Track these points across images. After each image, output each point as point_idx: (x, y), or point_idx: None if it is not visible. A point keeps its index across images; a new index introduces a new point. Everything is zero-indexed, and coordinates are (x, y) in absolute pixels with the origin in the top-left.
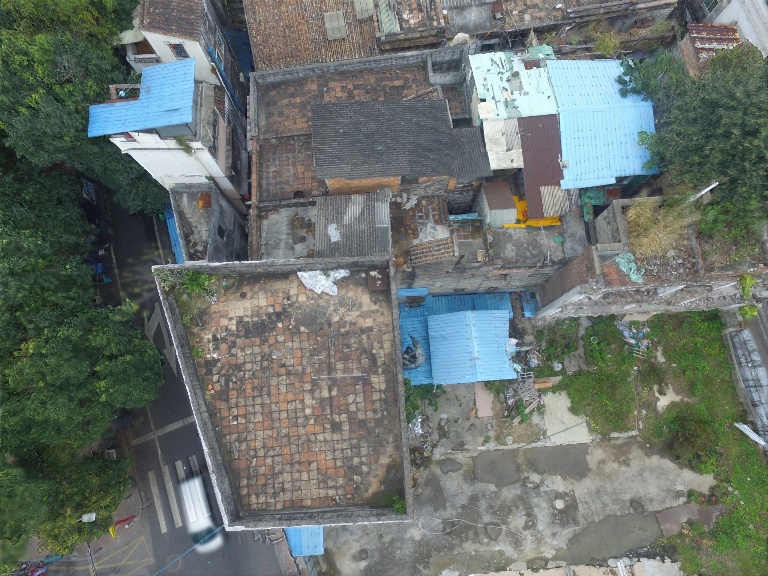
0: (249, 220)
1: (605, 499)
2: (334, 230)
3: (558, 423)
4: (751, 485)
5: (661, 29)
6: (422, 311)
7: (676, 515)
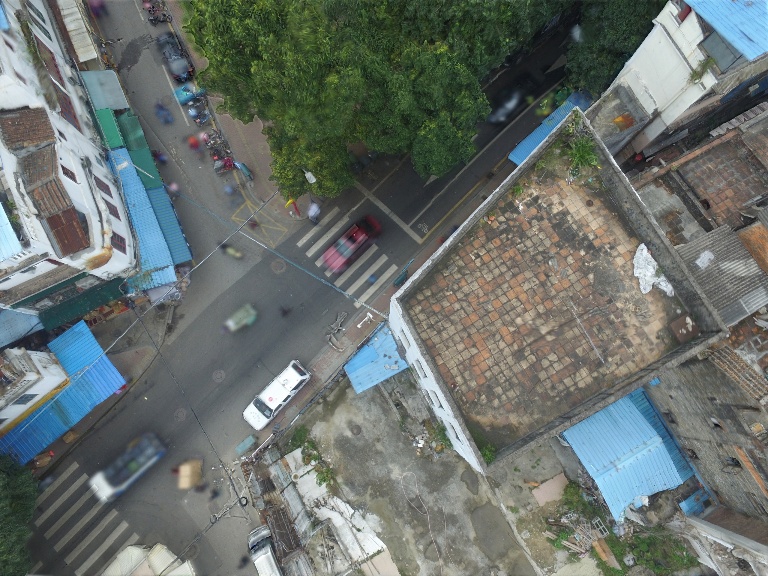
0: (645, 171)
1: None
2: (708, 258)
3: None
4: None
5: None
6: None
7: None
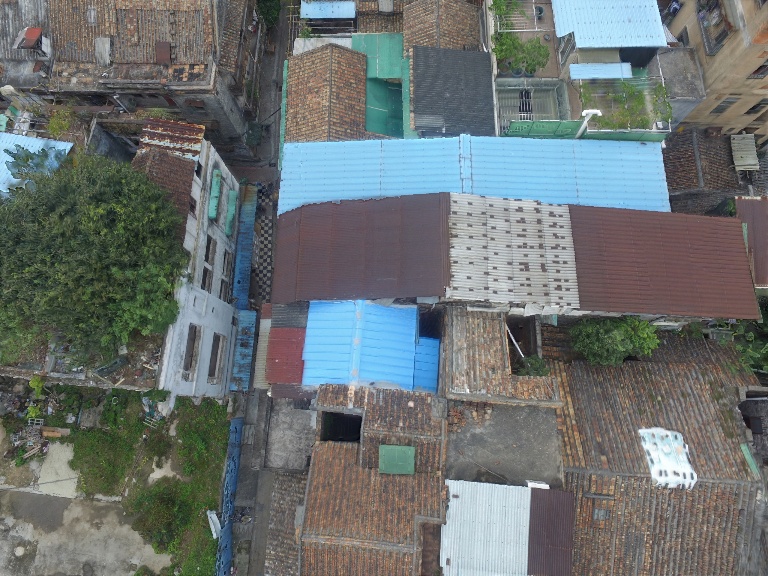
0: None
1: (62, 556)
2: None
3: (53, 473)
4: (196, 575)
5: (151, 116)
6: None
7: None
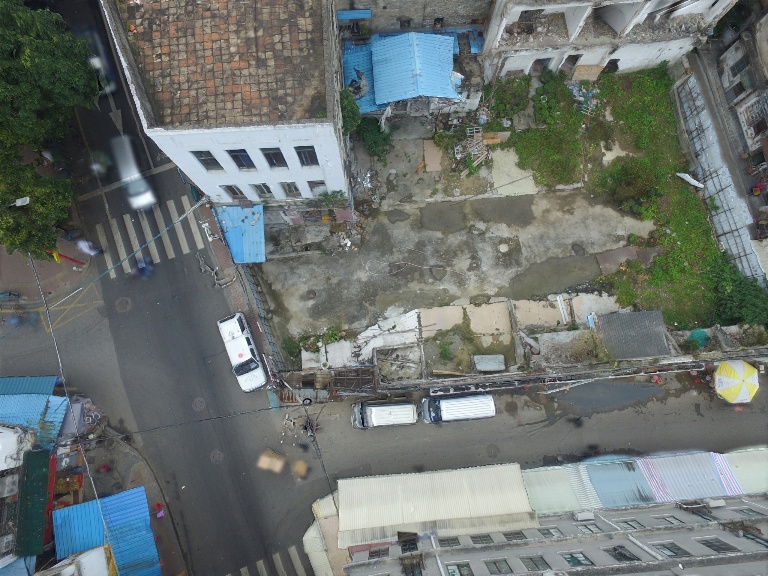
0: None
1: (548, 243)
2: None
3: (505, 177)
4: (689, 227)
5: None
6: (368, 48)
7: (615, 256)
